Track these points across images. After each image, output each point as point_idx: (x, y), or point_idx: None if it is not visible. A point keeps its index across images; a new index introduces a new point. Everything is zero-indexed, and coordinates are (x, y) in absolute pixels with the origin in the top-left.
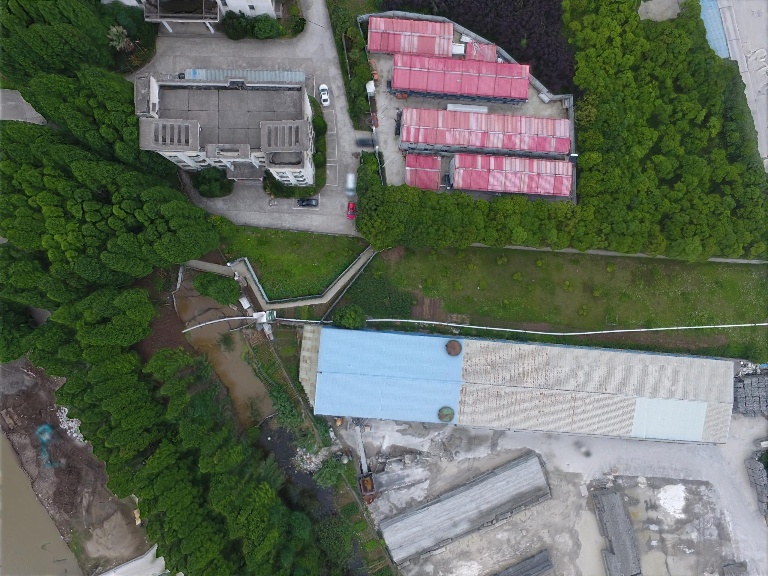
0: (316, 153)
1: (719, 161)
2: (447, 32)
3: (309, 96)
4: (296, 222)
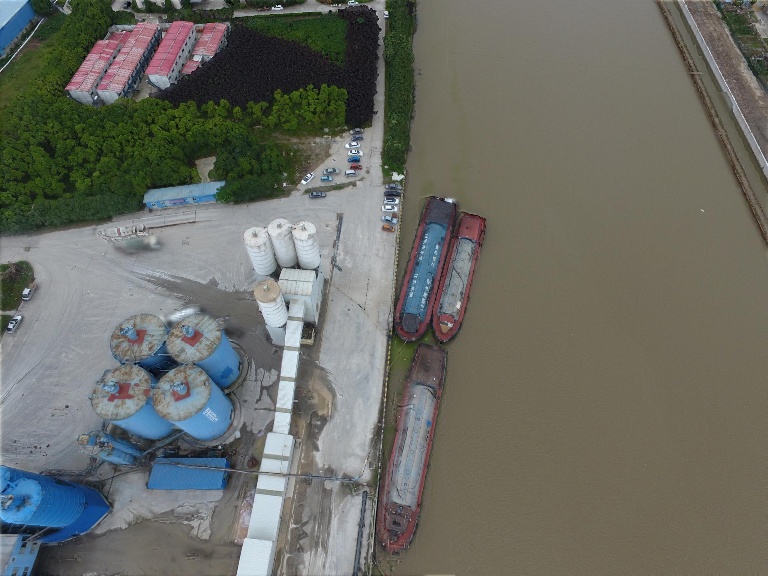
0: (151, 3)
1: (50, 179)
2: (208, 52)
3: (190, 7)
4: (118, 2)
